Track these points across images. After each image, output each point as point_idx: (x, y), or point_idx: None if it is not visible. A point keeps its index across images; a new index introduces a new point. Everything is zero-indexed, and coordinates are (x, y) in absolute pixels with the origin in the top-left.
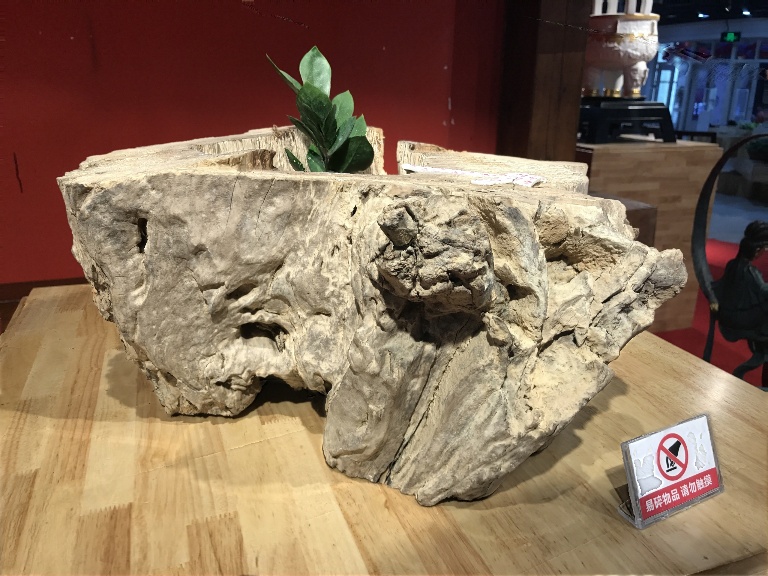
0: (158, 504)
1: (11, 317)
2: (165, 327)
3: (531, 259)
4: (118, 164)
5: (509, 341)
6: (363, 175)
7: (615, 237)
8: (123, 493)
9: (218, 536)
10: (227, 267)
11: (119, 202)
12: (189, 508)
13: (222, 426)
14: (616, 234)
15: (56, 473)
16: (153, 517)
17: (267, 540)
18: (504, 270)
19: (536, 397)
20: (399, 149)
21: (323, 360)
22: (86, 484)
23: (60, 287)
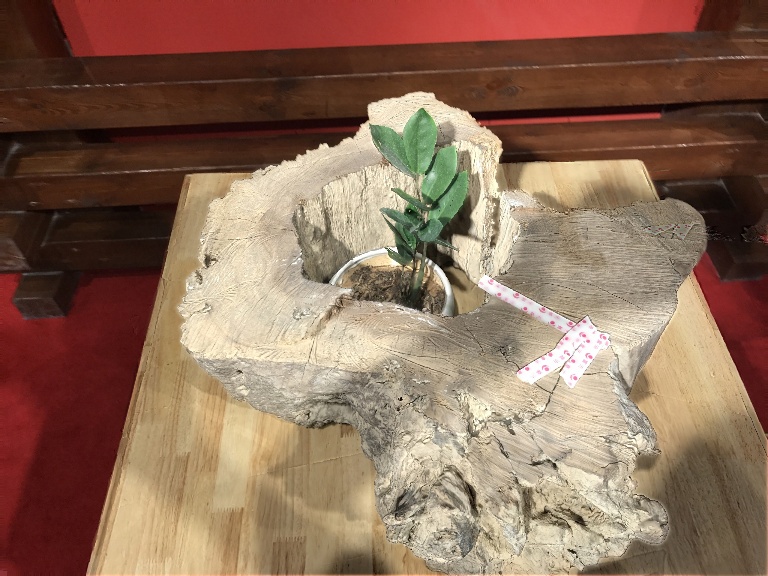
0: (259, 515)
1: (176, 209)
2: (264, 403)
3: (511, 534)
4: (227, 264)
5: (484, 565)
6: (430, 318)
7: (604, 508)
8: (239, 496)
9: (291, 559)
10: (304, 396)
11: (219, 367)
12: (277, 524)
13: (312, 431)
14: (607, 504)
15: (200, 460)
16: (254, 527)
17: (319, 572)
18: (488, 534)
19: (509, 572)
20: (503, 199)
21: (375, 456)
22: (217, 478)
23: (213, 175)
